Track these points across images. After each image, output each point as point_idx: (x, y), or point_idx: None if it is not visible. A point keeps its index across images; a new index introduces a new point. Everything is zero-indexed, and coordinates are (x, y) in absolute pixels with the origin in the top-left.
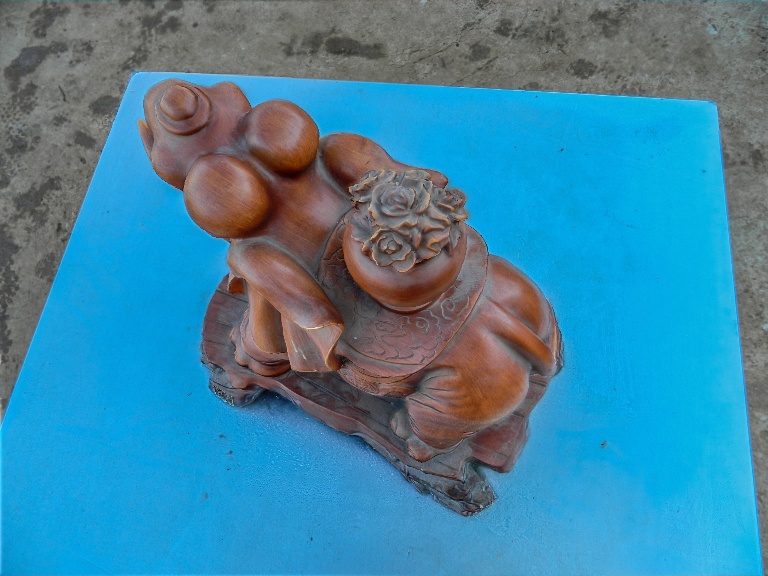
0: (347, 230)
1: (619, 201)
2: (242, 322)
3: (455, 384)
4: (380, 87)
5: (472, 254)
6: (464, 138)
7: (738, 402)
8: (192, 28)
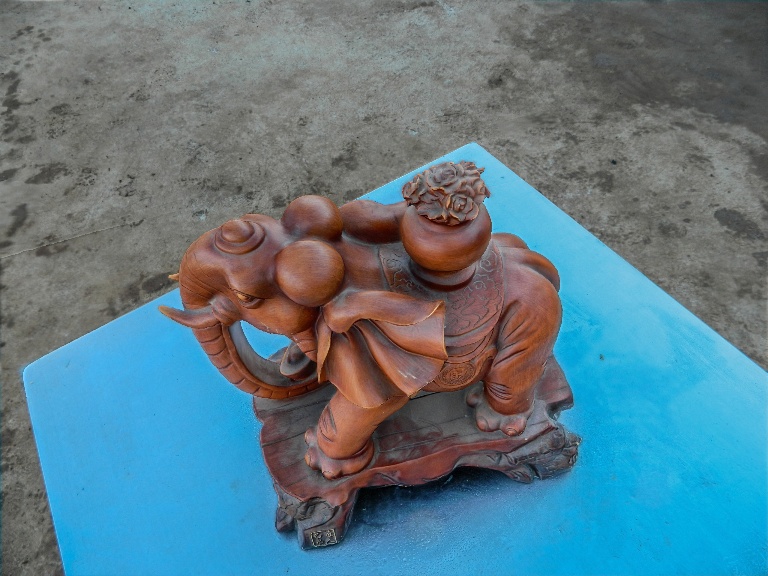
0: (410, 235)
1: None
2: (323, 427)
3: (524, 313)
4: None
5: None
6: None
7: (641, 279)
8: (1, 349)
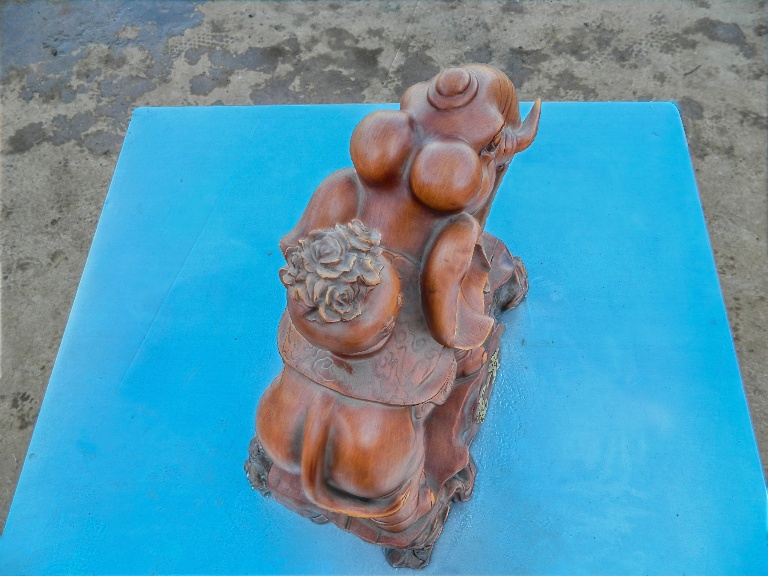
0: None
1: None
2: None
3: (272, 388)
4: (726, 344)
5: (390, 388)
6: (675, 449)
7: None
8: None
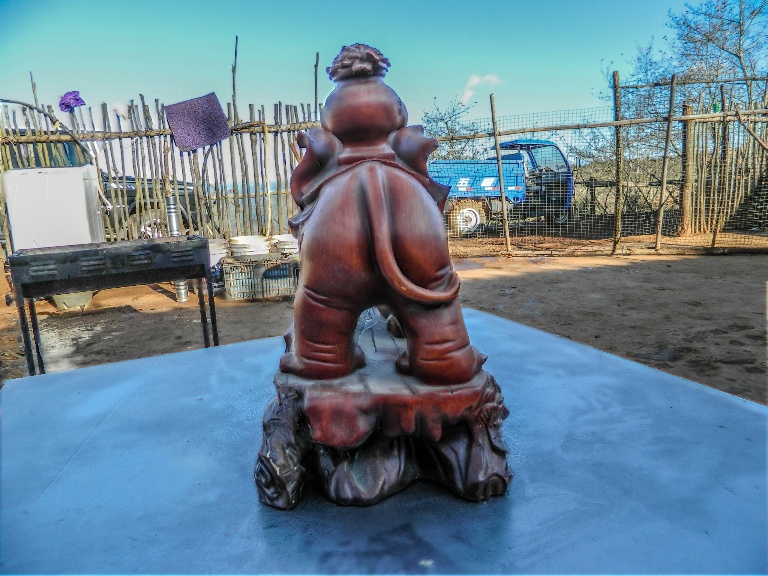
0: None
1: (742, 473)
2: None
3: None
4: (602, 352)
5: None
6: (629, 386)
7: None
8: None
